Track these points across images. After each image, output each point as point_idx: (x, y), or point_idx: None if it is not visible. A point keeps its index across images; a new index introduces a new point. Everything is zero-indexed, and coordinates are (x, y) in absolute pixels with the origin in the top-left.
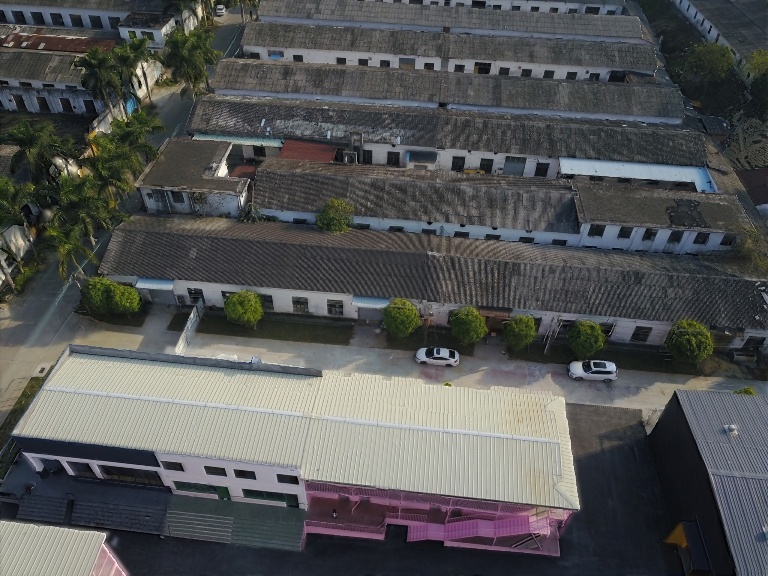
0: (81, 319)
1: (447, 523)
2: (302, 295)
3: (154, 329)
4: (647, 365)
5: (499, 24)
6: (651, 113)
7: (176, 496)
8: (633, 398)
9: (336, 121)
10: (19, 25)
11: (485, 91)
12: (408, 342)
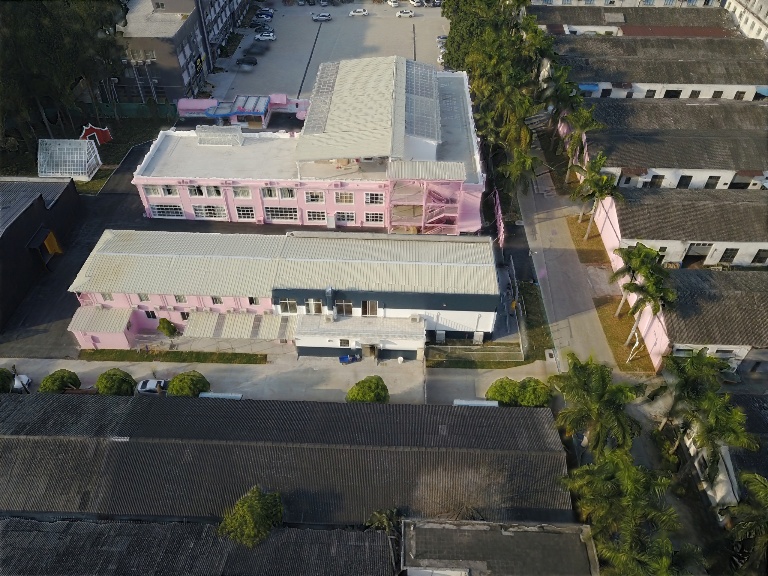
0: None
1: None
2: None
3: None
4: None
5: None
6: None
7: None
8: None
9: None
10: None
11: None
12: None
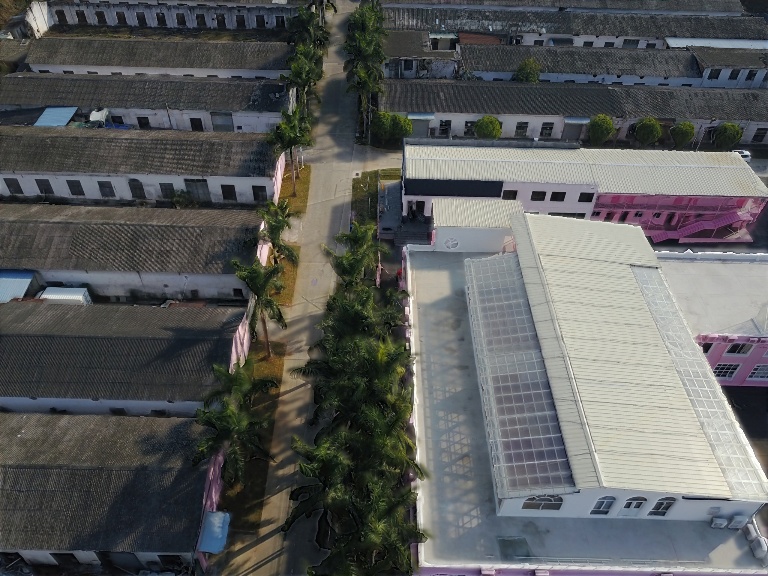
0: (364, 147)
1: (679, 229)
2: (526, 120)
3: None
4: (766, 155)
5: None
6: (719, 9)
7: None
8: (764, 172)
9: (493, 19)
10: None
11: None
12: None
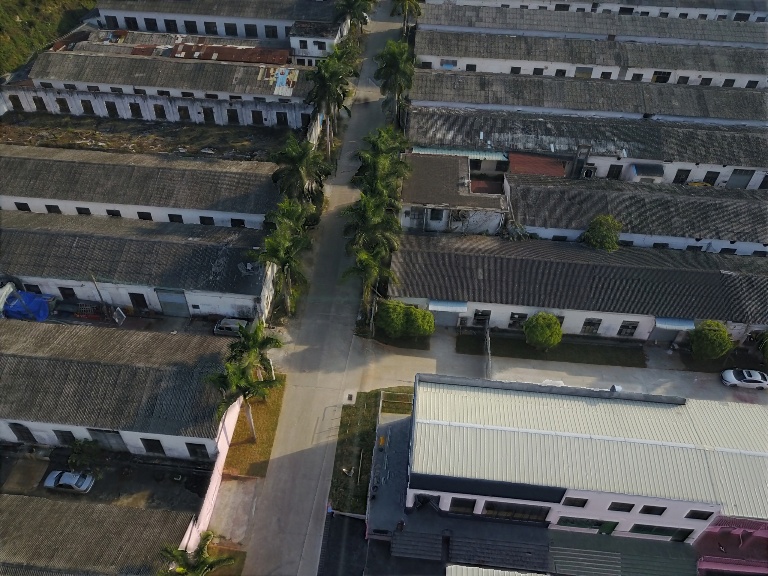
0: (366, 342)
1: None
2: (598, 316)
3: (443, 352)
4: None
5: (665, 32)
6: None
7: (552, 531)
8: None
9: (556, 134)
10: (179, 34)
11: (689, 101)
12: (707, 364)
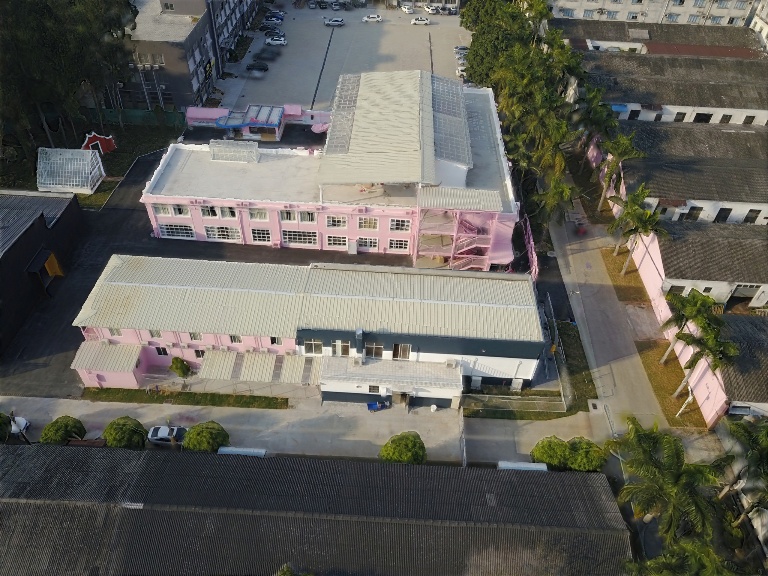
0: None
1: None
2: None
3: None
4: None
5: None
6: None
7: None
8: None
9: None
10: None
11: None
12: None
